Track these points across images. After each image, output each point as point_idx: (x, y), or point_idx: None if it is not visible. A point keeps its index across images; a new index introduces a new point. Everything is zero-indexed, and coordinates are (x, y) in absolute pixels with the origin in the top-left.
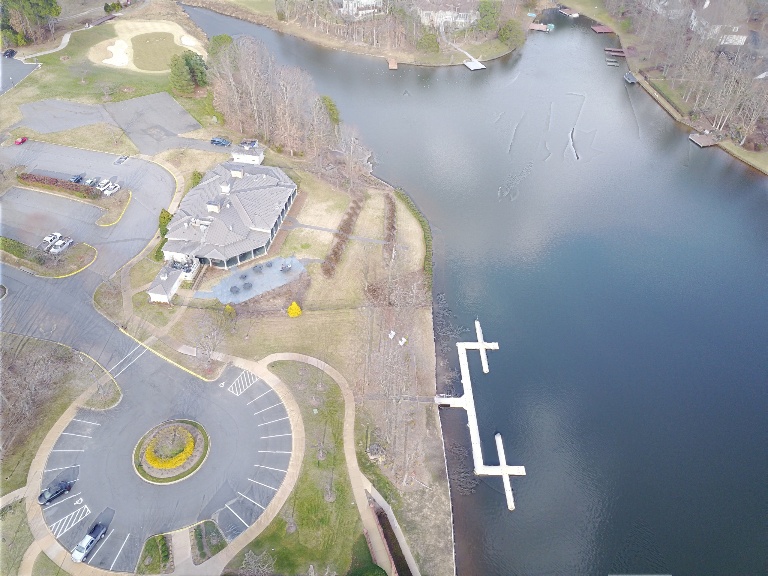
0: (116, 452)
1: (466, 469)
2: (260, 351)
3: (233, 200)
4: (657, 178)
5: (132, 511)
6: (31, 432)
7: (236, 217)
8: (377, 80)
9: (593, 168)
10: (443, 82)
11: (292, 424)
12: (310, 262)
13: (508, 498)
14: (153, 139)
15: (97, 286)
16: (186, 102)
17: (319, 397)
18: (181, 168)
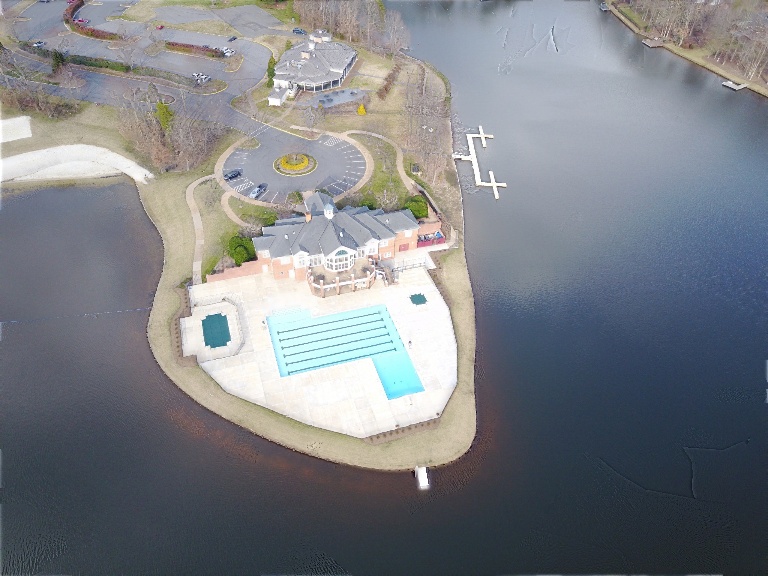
0: (263, 164)
1: (471, 184)
2: (342, 129)
3: (317, 54)
4: (618, 72)
5: (278, 184)
6: (210, 156)
7: (320, 63)
8: (408, 10)
9: (569, 59)
10: (459, 12)
11: (365, 157)
12: (369, 91)
13: (495, 194)
14: (251, 29)
15: (232, 99)
16: (270, 11)
17: (380, 148)
18: (274, 45)
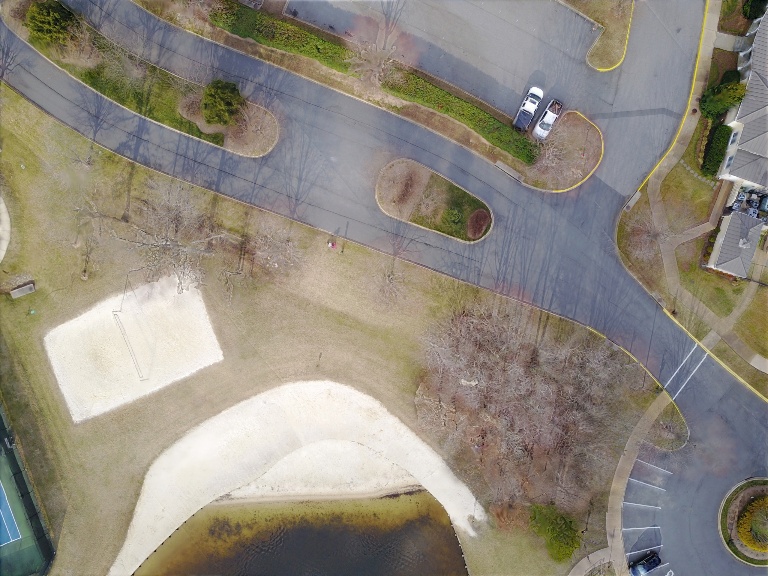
0: (698, 516)
1: None
2: None
3: None
4: None
5: None
6: (590, 469)
7: None
8: None
9: None
10: None
11: None
12: None
13: None
14: None
15: (617, 217)
16: None
17: None
18: None
